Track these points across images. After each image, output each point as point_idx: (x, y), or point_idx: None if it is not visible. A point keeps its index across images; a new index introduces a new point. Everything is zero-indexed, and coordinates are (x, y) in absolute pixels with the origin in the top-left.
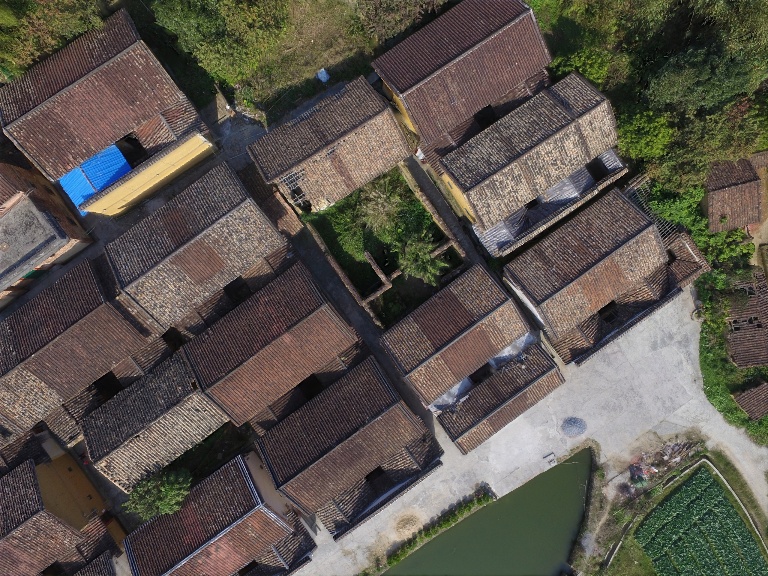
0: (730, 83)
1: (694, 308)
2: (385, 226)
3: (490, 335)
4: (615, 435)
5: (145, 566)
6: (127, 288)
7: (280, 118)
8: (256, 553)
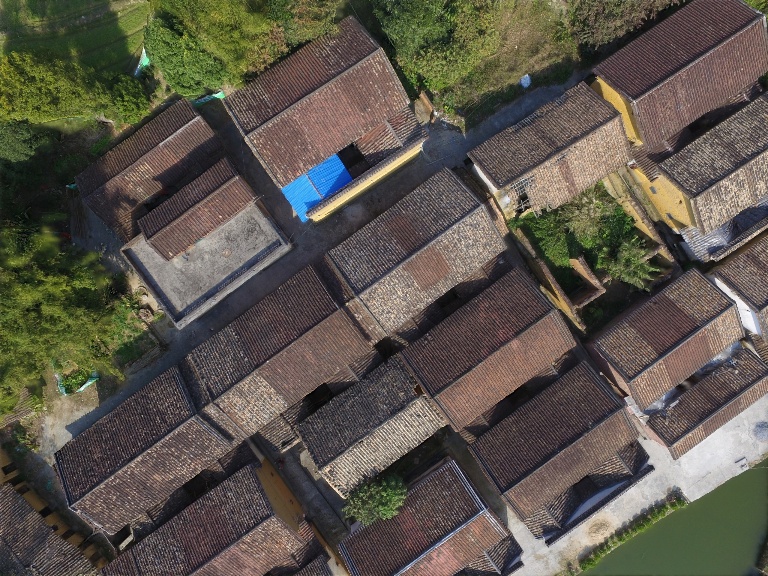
0: None
1: None
2: (588, 231)
3: (710, 340)
4: None
5: (366, 571)
6: (361, 294)
7: (478, 124)
8: (471, 558)
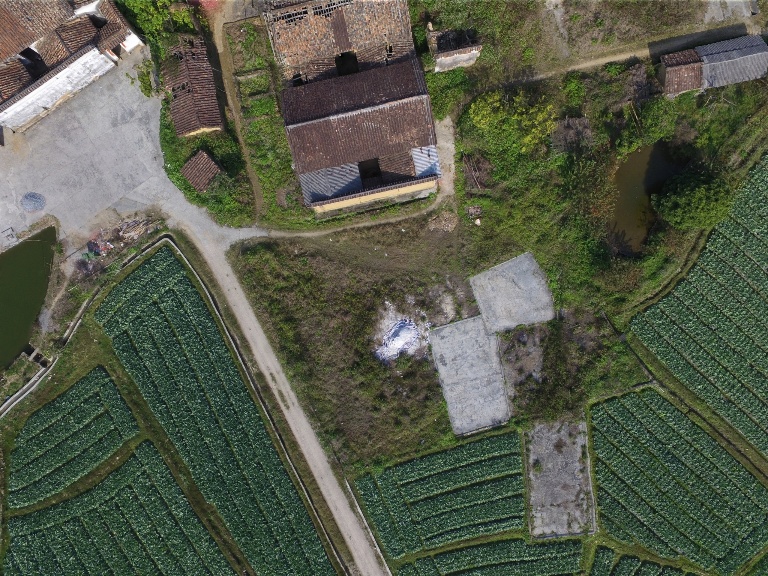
0: None
1: (155, 85)
2: None
3: None
4: (74, 211)
5: None
6: None
7: None
8: None
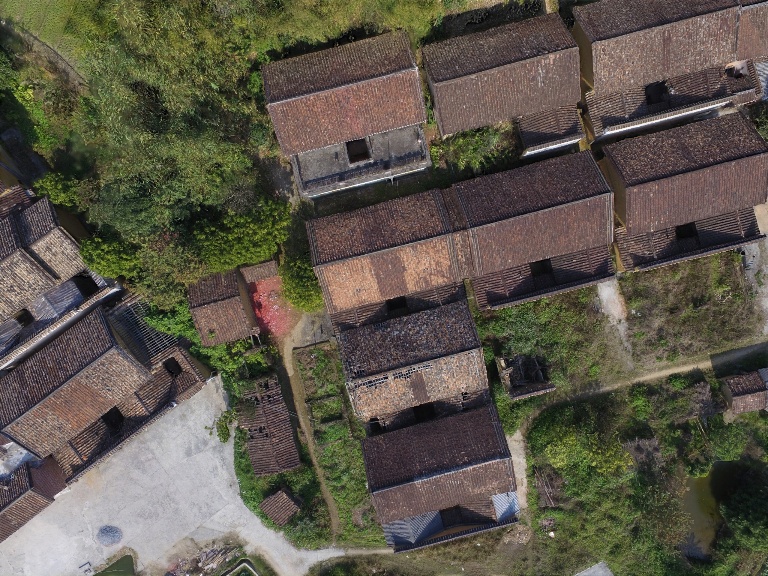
0: (137, 218)
1: None
2: None
3: None
4: (151, 542)
5: None
6: None
7: None
8: None
